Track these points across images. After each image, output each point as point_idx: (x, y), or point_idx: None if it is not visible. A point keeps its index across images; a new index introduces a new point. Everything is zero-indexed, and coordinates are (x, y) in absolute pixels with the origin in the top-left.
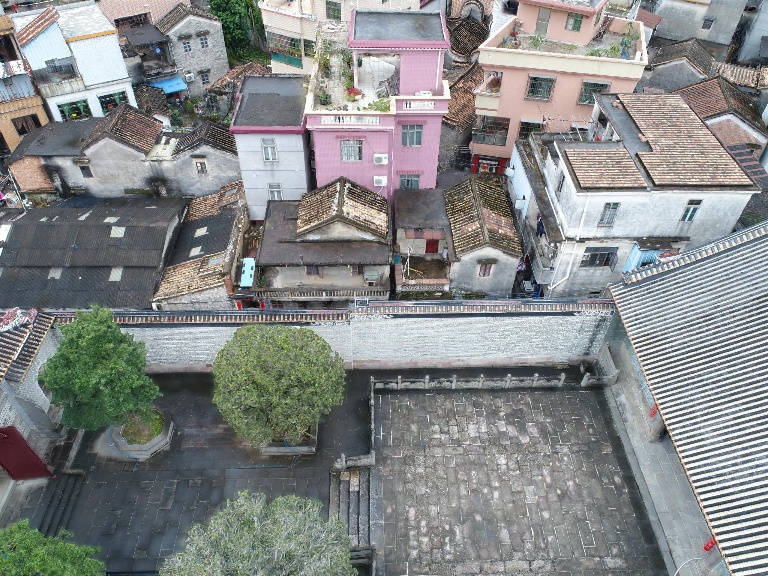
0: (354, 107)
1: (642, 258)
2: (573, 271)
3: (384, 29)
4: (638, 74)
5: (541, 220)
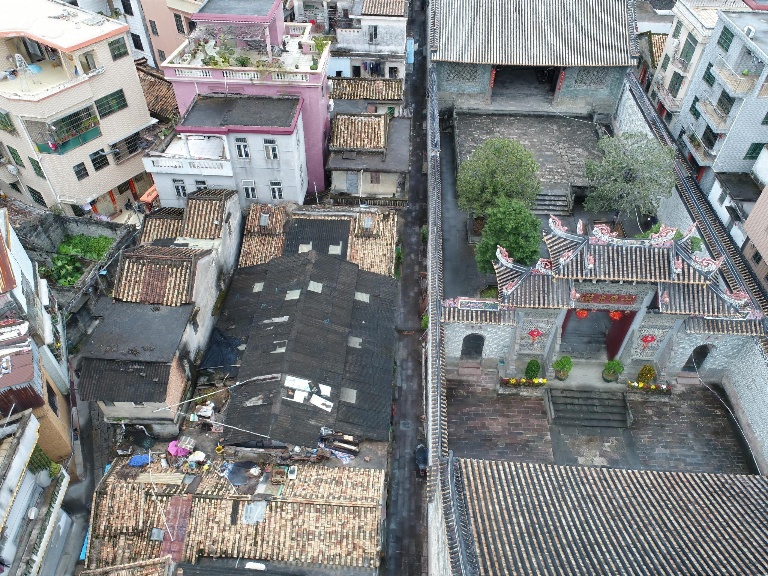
0: (293, 66)
1: (413, 44)
2: None
3: (240, 8)
4: None
5: (373, 65)
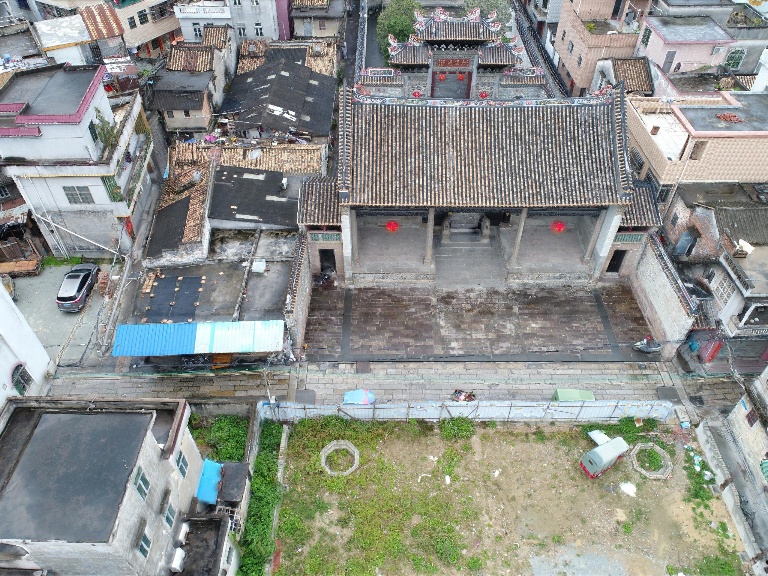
0: None
1: None
2: None
3: None
4: None
5: None
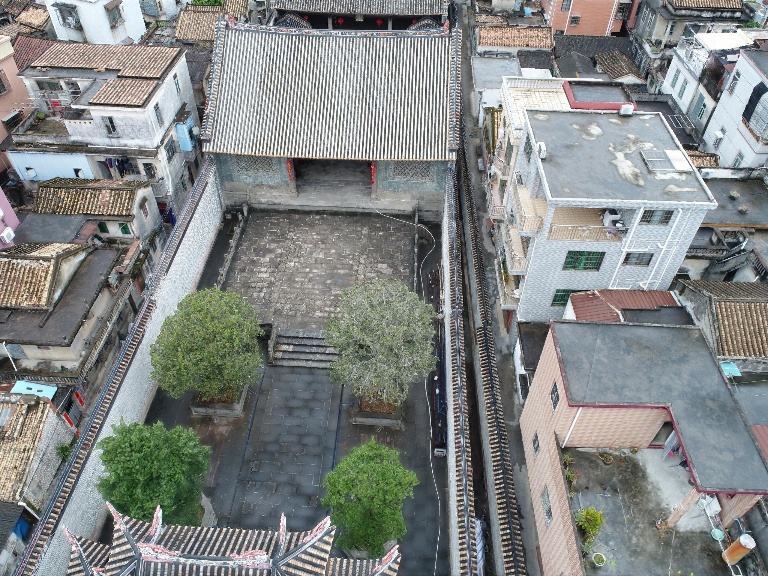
0: None
1: (187, 129)
2: (169, 171)
3: None
4: (10, 49)
5: (118, 162)
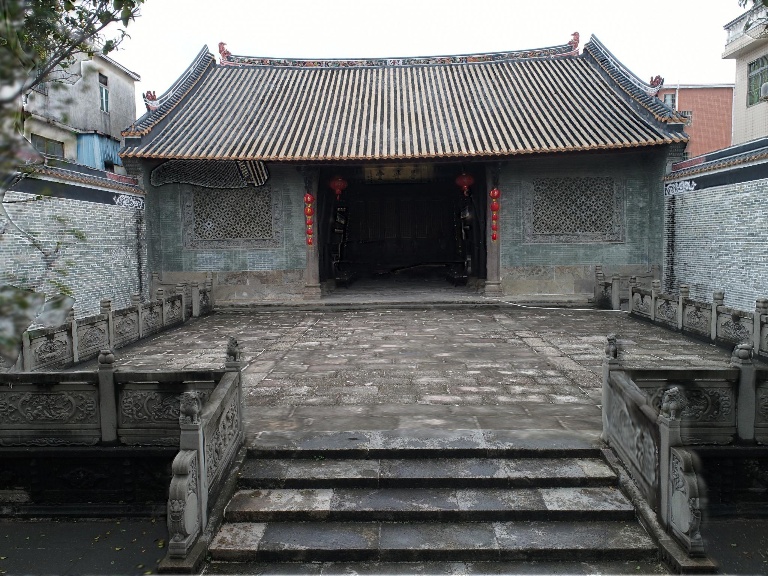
0: None
1: (101, 152)
2: None
3: None
4: None
5: None
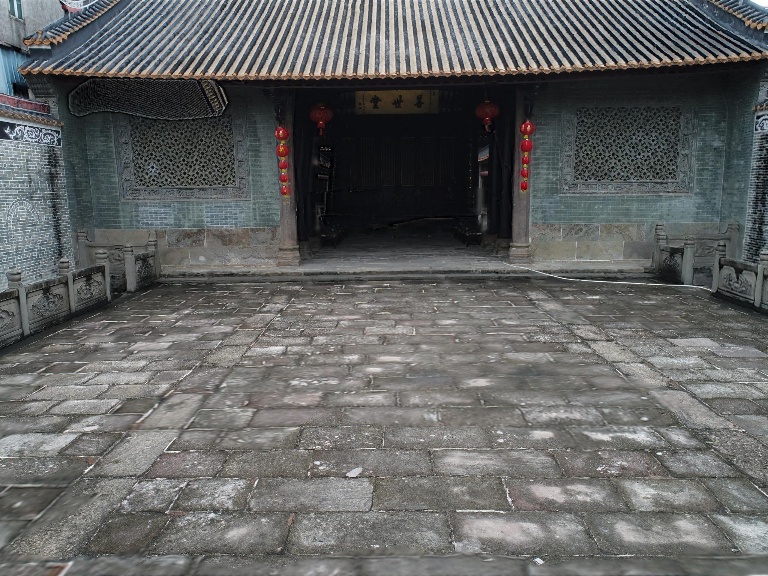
0: None
1: (7, 70)
2: None
3: None
4: None
5: None
